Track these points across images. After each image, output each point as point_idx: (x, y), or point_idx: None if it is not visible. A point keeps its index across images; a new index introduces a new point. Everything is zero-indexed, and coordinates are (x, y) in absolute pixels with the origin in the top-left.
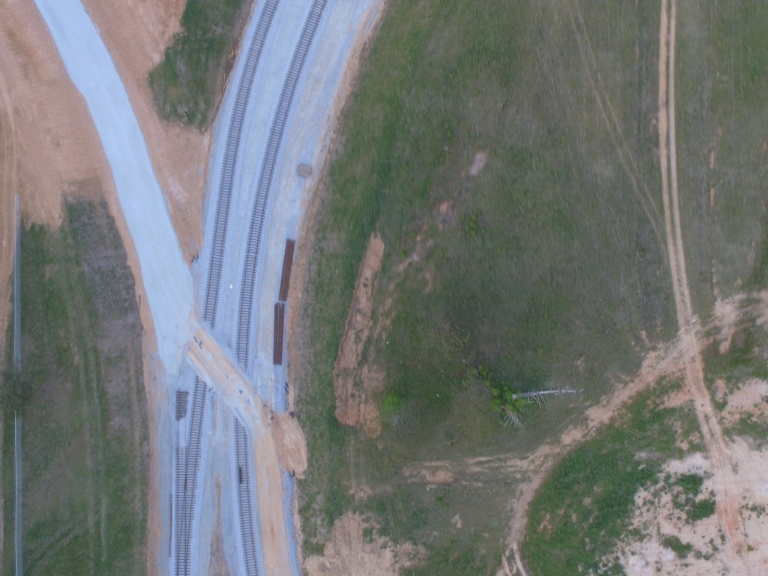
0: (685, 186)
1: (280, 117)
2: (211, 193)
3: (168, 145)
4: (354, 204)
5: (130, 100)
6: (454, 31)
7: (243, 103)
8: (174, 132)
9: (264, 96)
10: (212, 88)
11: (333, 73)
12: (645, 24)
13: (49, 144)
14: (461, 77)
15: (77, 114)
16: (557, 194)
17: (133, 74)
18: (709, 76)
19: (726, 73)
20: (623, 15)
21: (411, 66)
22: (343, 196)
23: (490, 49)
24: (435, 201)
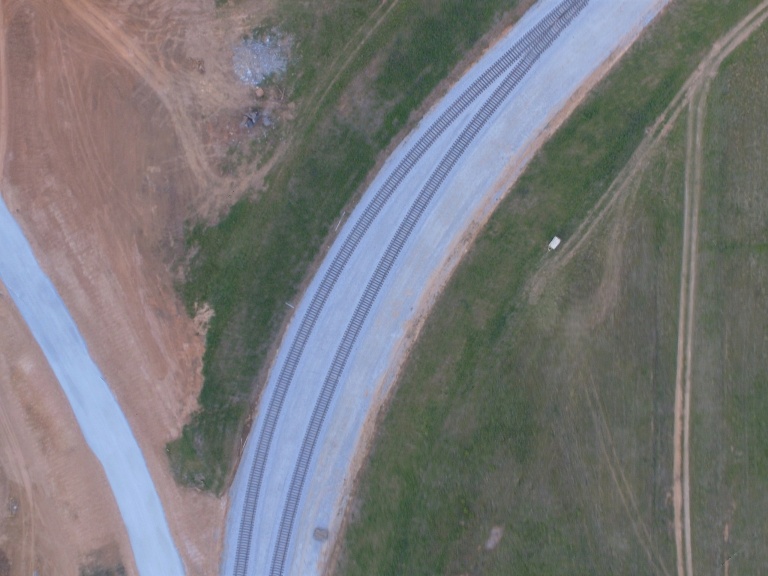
0: (700, 559)
1: (297, 482)
2: (228, 557)
3: (185, 509)
4: (371, 575)
5: (147, 466)
6: (470, 408)
7: (260, 468)
8: (191, 496)
9: (281, 461)
10: (229, 454)
11: (349, 437)
12: (660, 399)
13: (67, 518)
14: (477, 453)
15: (94, 480)
16: (573, 567)
17: (150, 441)
18: (723, 450)
19: (740, 448)
20: (638, 392)
21: (428, 443)
22: (360, 564)
23: (506, 426)
24: (451, 574)
